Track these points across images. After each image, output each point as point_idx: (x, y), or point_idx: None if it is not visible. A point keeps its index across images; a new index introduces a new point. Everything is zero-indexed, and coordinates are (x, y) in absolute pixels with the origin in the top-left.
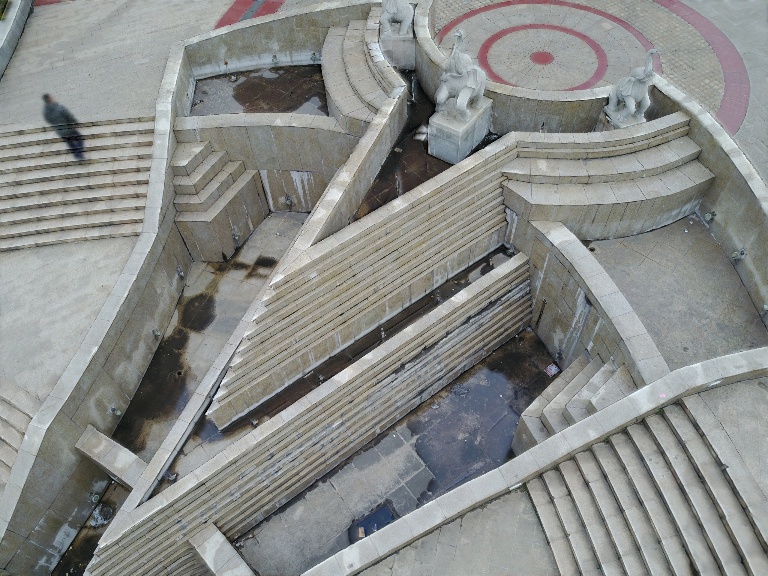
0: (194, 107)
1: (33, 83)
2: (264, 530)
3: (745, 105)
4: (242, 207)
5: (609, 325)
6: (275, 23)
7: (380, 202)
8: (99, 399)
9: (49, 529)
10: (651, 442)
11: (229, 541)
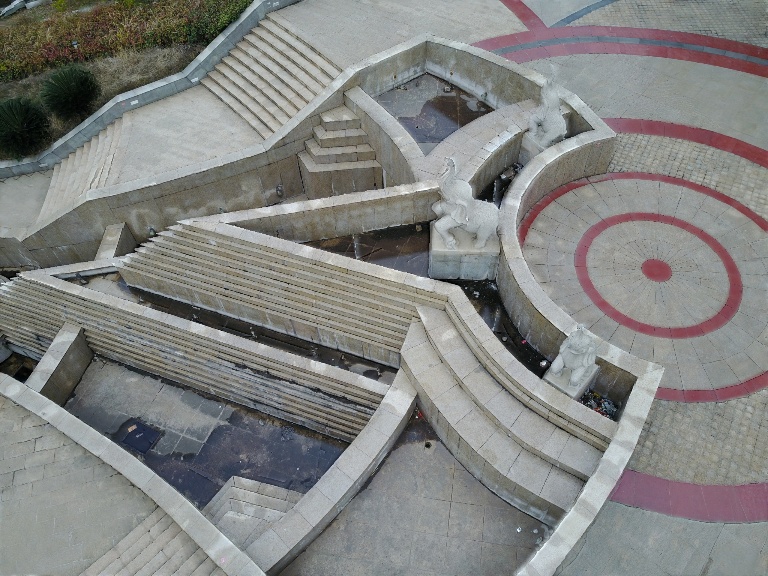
0: (396, 89)
1: (336, 4)
2: (111, 366)
3: None
4: (351, 183)
5: None
6: (495, 66)
7: (348, 248)
8: (142, 214)
9: (69, 256)
10: None
11: (78, 346)
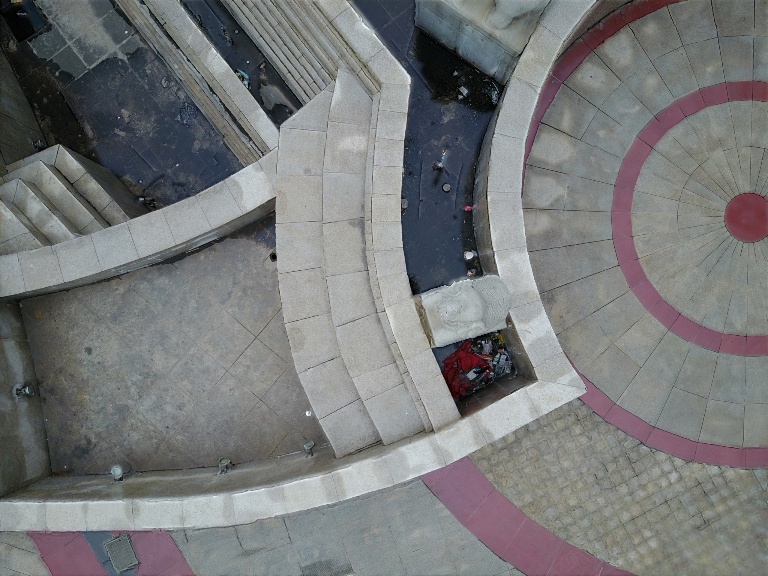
0: None
1: None
2: None
3: None
4: None
5: None
6: None
7: None
8: None
9: None
10: None
11: None
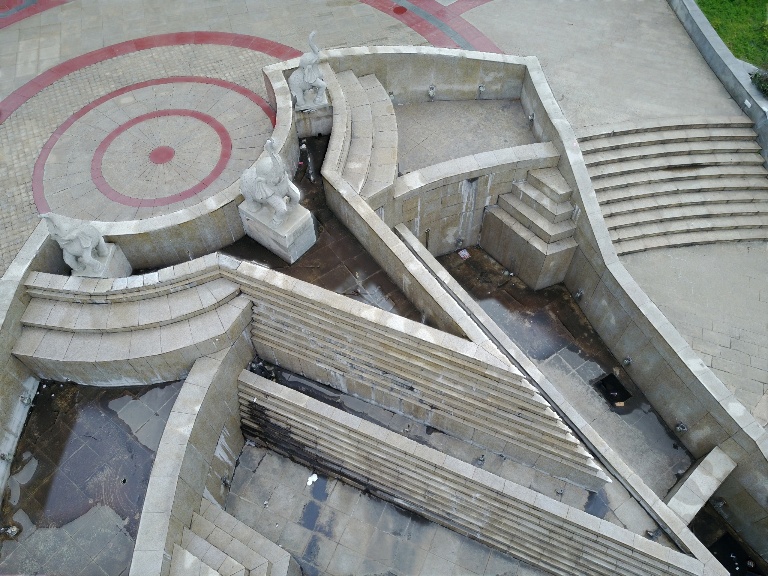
0: None
1: None
2: None
3: (279, 45)
4: None
5: (501, 169)
6: None
7: None
8: None
9: None
10: (589, 169)
11: None
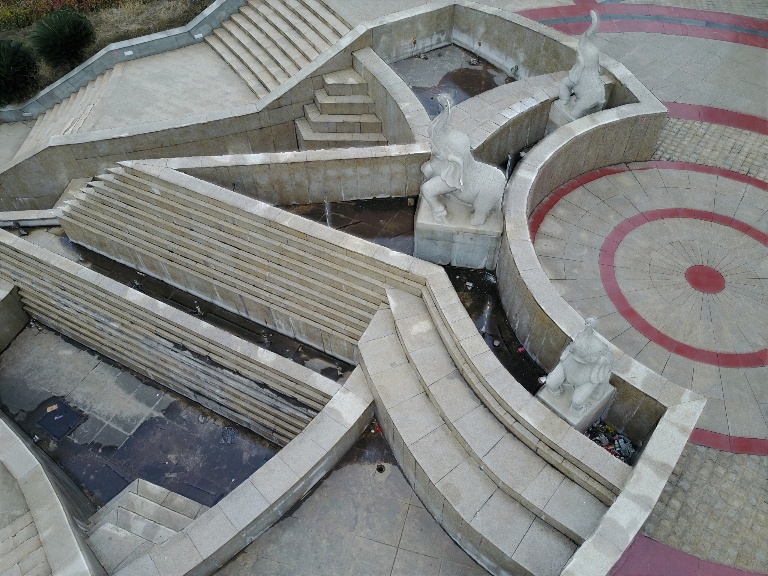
0: (415, 58)
1: None
2: (46, 335)
3: None
4: None
5: None
6: (529, 32)
7: (321, 217)
8: None
9: None
10: None
11: (8, 306)
